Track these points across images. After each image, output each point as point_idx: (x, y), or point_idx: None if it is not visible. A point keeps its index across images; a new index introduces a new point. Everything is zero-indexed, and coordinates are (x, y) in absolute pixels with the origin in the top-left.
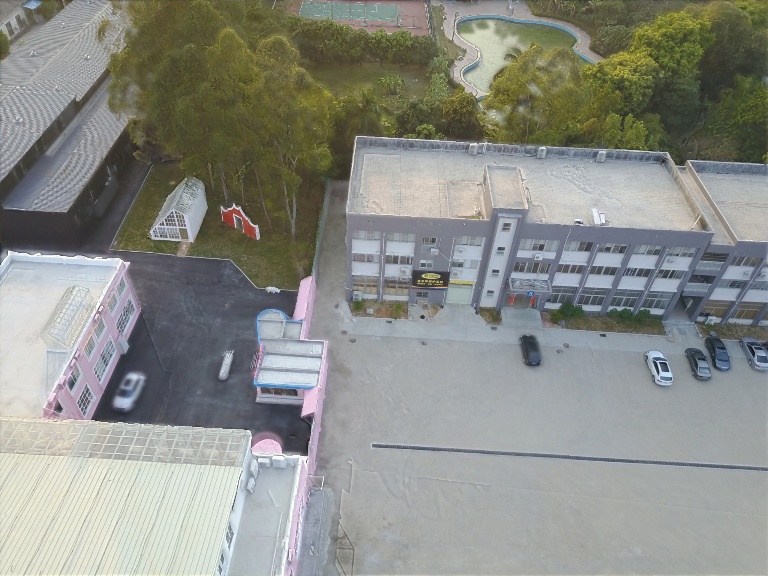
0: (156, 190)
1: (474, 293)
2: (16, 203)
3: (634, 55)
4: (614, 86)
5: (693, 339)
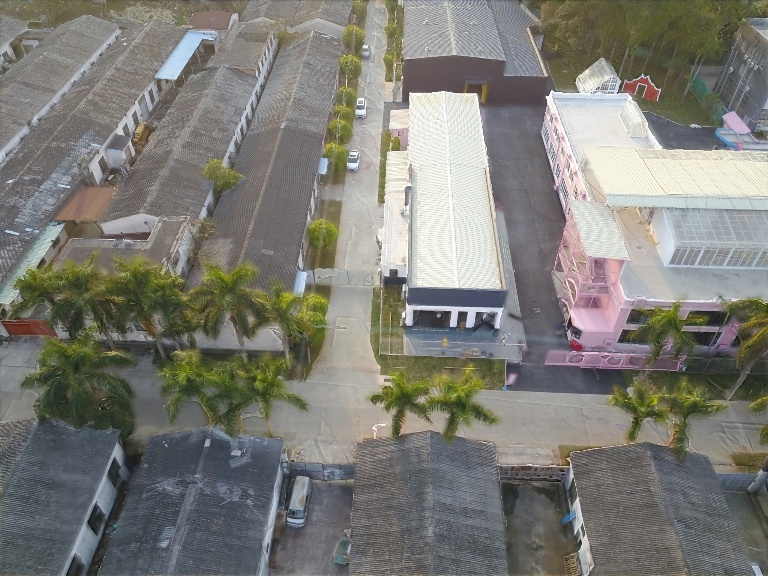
0: (559, 75)
1: None
2: (508, 73)
3: None
4: None
5: None
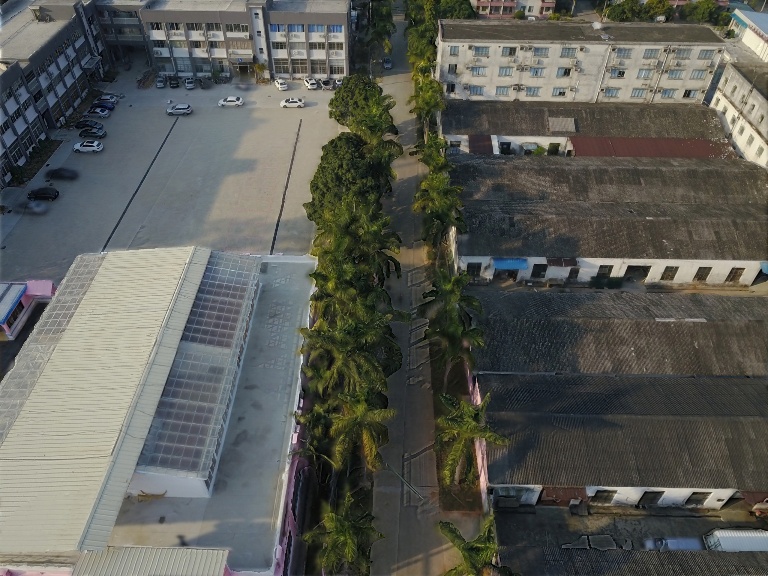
0: None
1: None
2: None
3: None
4: None
5: (72, 133)
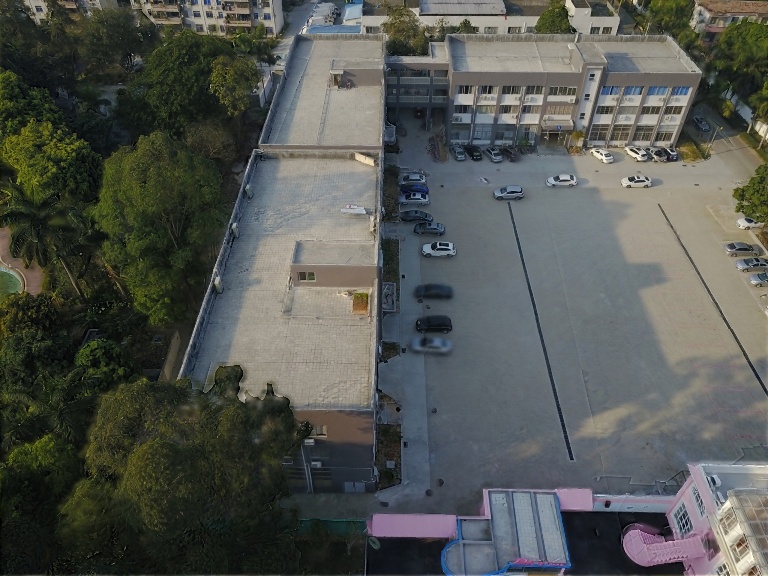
0: None
1: None
2: None
3: (11, 135)
4: (79, 163)
5: (401, 227)
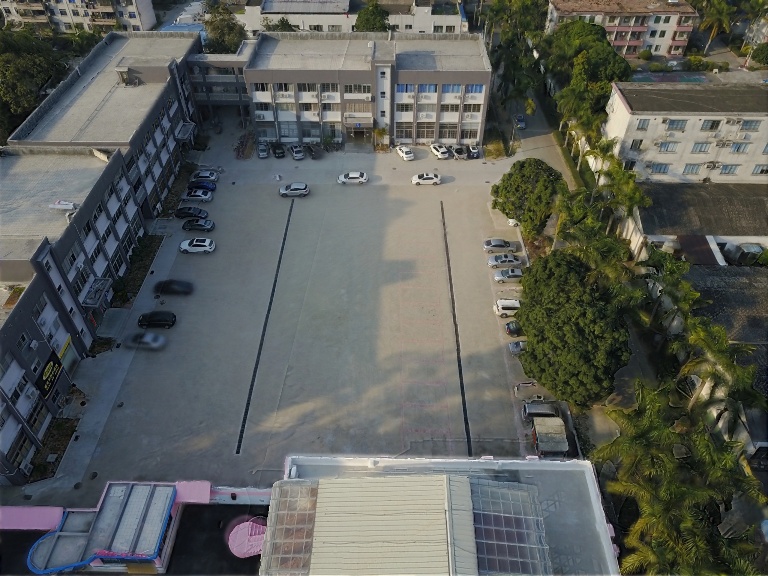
0: None
1: (75, 347)
2: None
3: None
4: None
5: (172, 223)
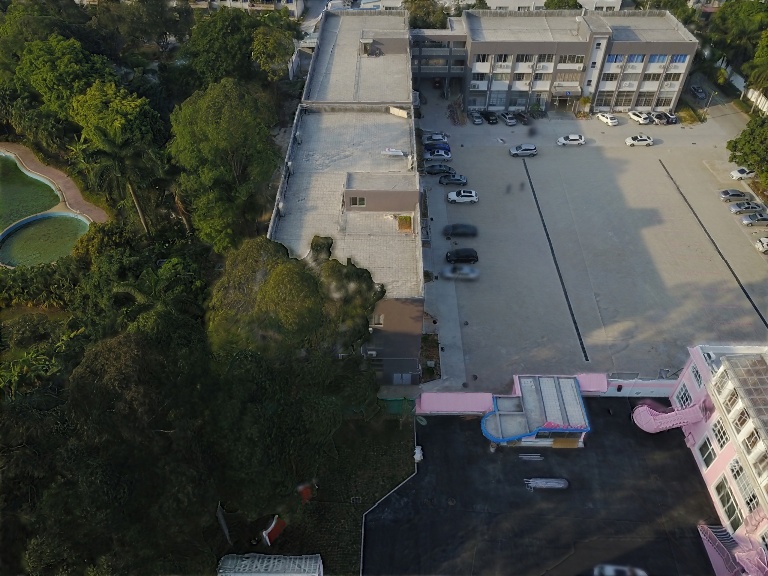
0: None
1: None
2: None
3: (77, 95)
4: (142, 117)
5: (427, 179)
